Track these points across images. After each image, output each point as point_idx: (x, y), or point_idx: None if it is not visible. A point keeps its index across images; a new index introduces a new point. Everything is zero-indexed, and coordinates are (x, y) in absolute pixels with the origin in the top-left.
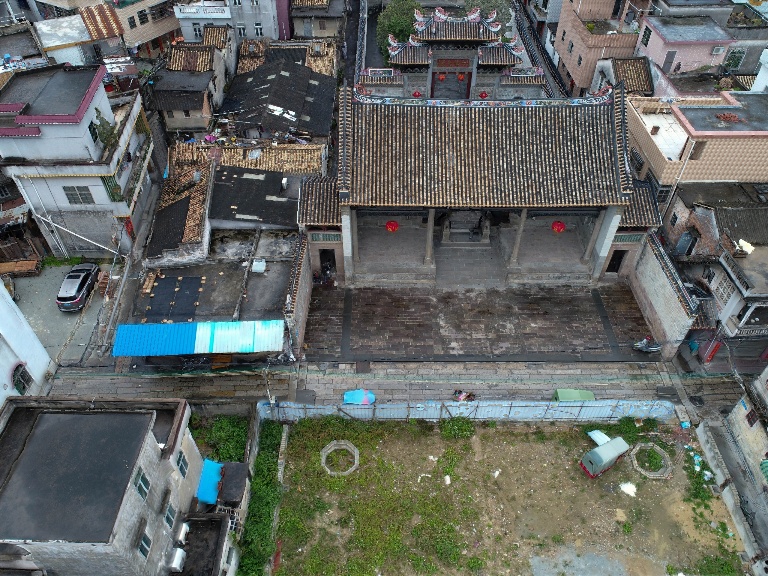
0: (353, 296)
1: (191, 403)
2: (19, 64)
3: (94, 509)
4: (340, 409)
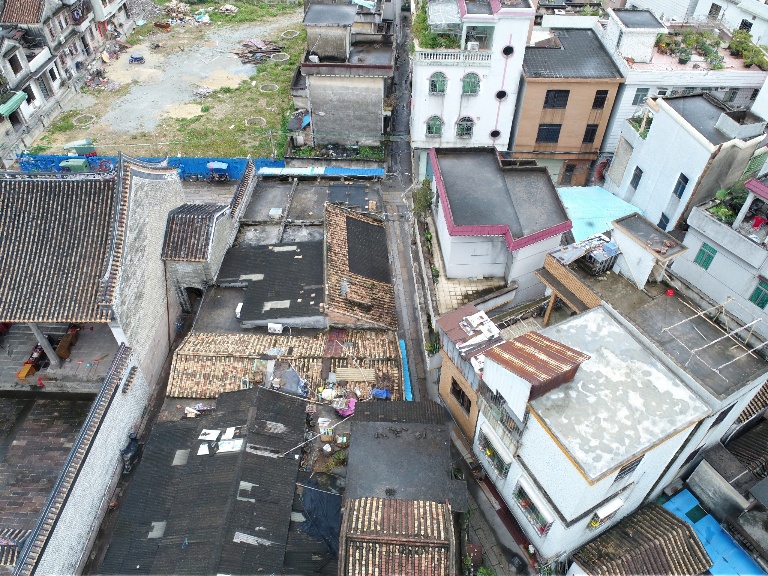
0: None
1: None
2: (586, 244)
3: (319, 7)
4: (232, 163)
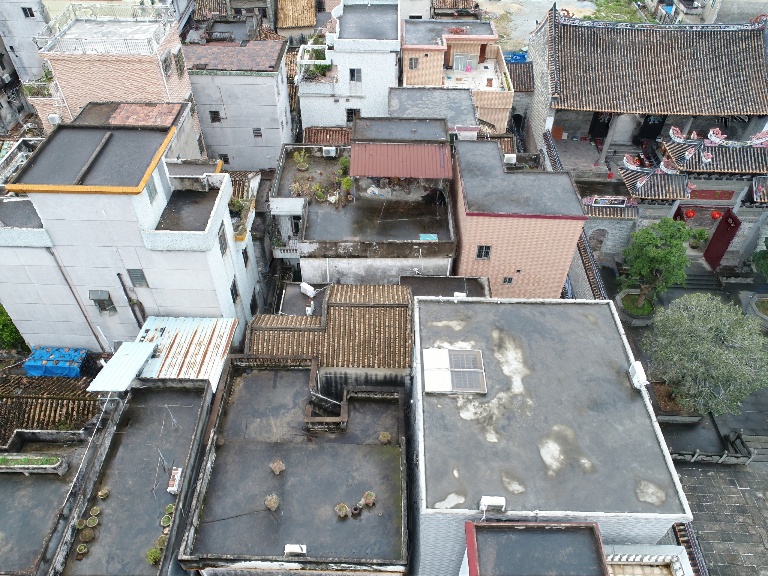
0: None
1: None
2: None
3: None
4: None
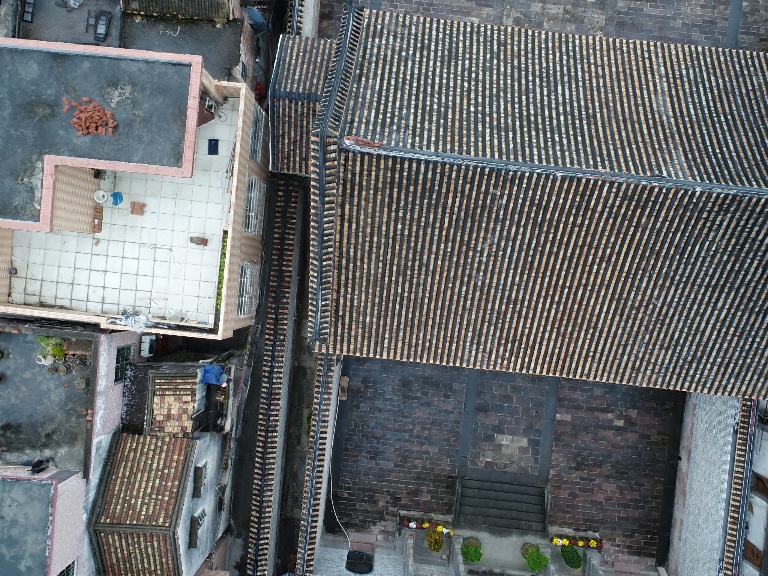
0: None
1: None
2: None
3: None
4: None
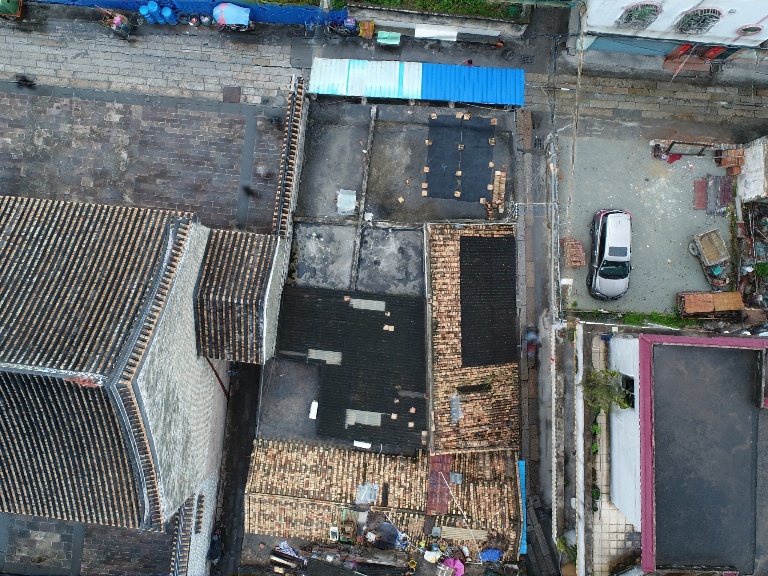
0: (236, 214)
1: (422, 10)
2: None
3: None
4: (255, 4)
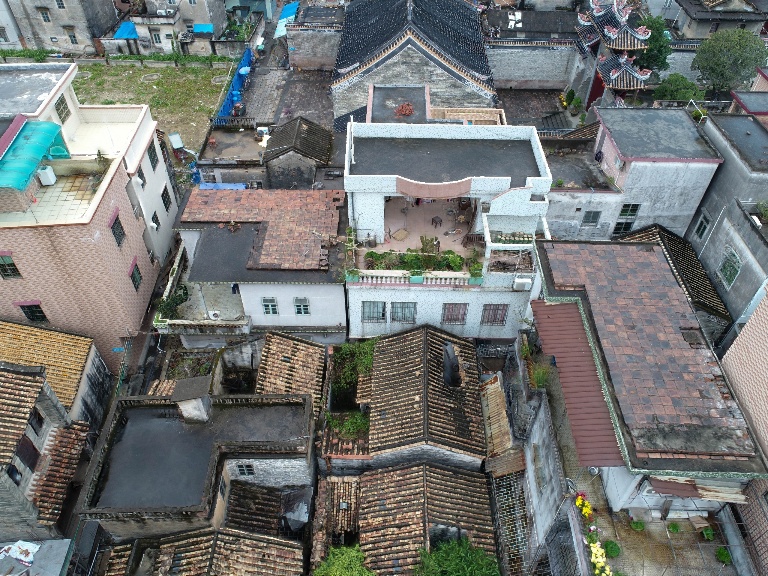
0: None
1: None
2: None
3: None
4: None
